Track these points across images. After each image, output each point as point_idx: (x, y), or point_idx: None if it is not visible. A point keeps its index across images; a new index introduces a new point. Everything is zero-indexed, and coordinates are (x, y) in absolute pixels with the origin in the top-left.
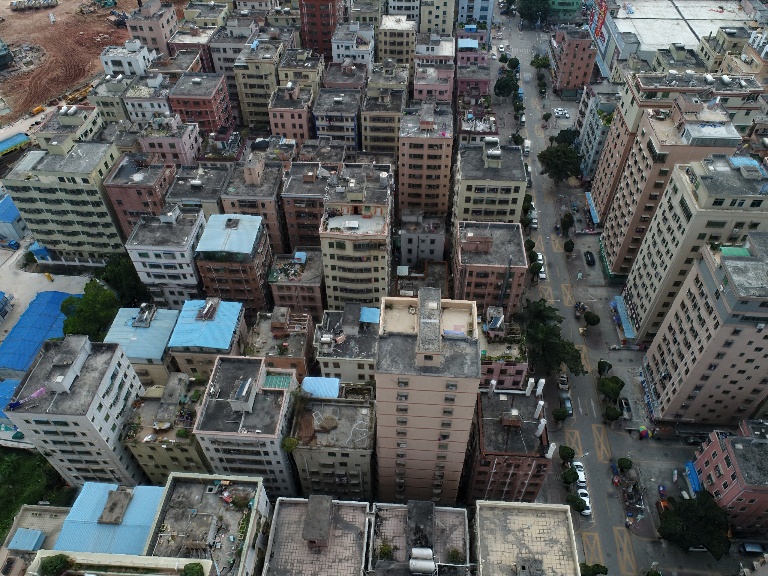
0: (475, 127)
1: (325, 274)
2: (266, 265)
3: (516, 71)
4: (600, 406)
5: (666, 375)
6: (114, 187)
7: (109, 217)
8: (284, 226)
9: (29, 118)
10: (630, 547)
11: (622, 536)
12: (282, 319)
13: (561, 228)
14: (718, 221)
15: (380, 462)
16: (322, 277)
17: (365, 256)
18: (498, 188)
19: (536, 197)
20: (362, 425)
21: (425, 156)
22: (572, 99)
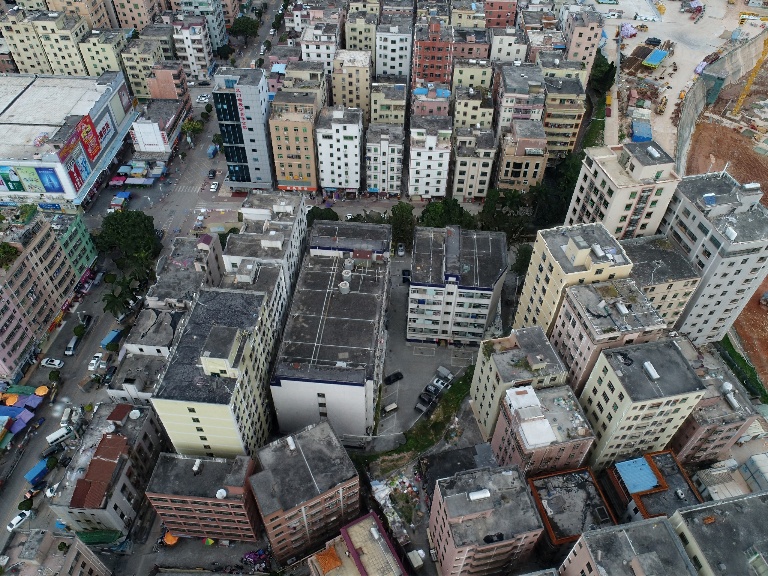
0: (303, 3)
1: None
2: None
3: None
4: None
5: None
6: None
7: None
8: None
9: None
10: None
11: None
12: None
13: None
14: None
15: None
16: None
17: None
18: None
19: (265, 39)
20: None
21: None
22: None
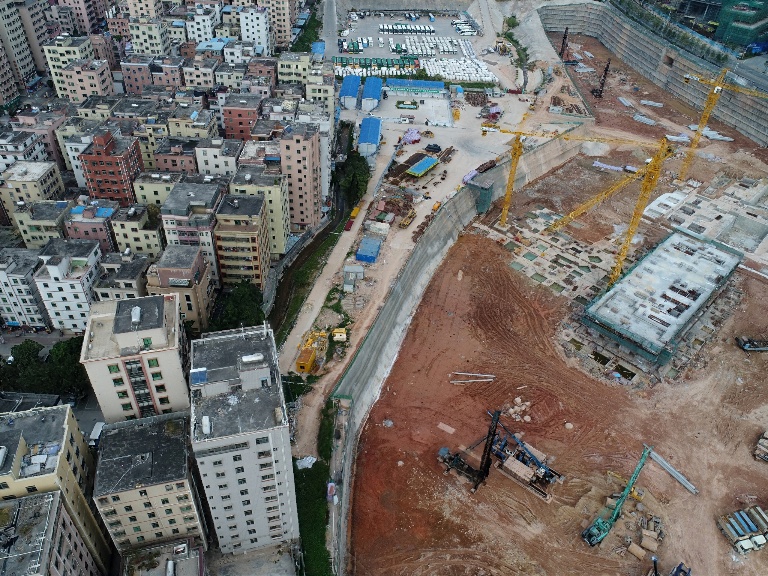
0: None
1: None
2: None
3: None
4: None
5: None
6: None
7: None
8: None
9: None
10: None
11: None
12: (191, 39)
13: None
14: None
15: None
16: None
17: None
18: None
19: None
20: None
21: None
22: None
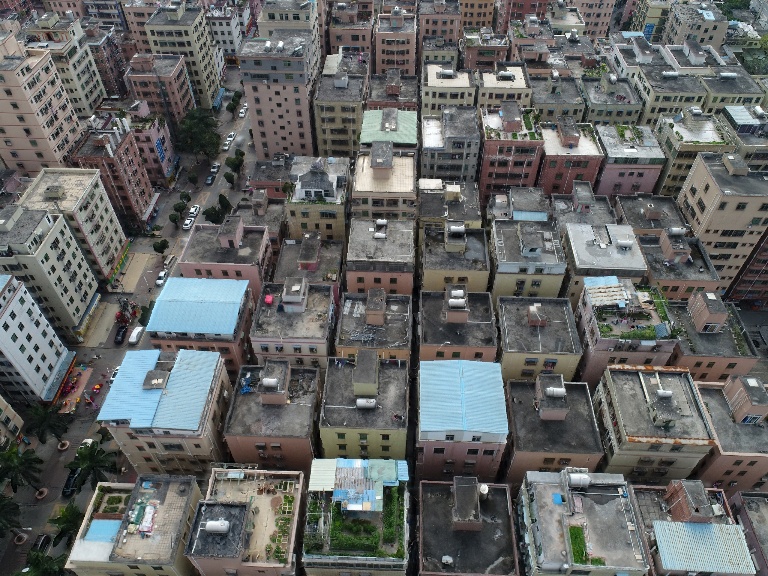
0: (212, 13)
1: None
2: None
3: None
4: None
5: None
6: None
7: None
8: None
9: None
10: None
11: None
12: None
13: None
14: None
15: (8, 166)
16: None
17: None
18: (173, 32)
19: None
20: None
21: None
22: None
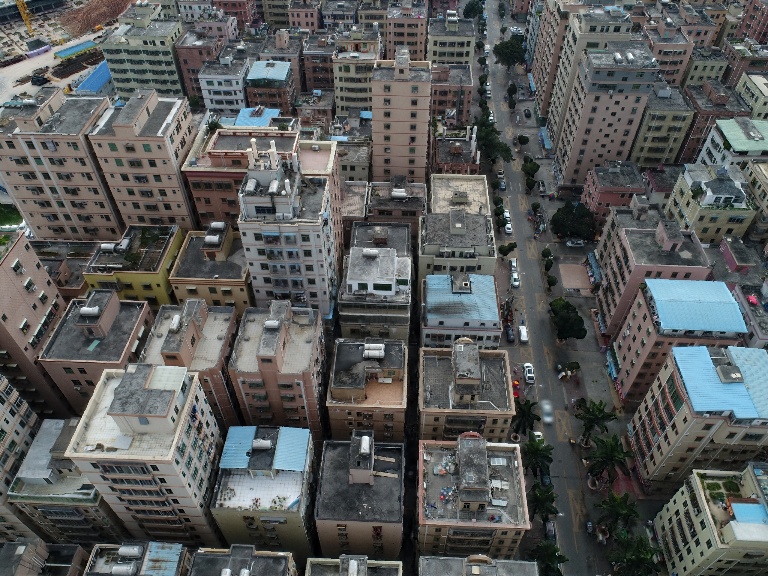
0: None
1: (336, 95)
2: (293, 99)
3: (482, 3)
4: (525, 186)
5: (564, 152)
6: (183, 48)
7: (176, 75)
8: (303, 84)
9: (92, 34)
10: (535, 247)
11: (531, 242)
12: (308, 115)
13: (508, 97)
14: (593, 42)
15: (374, 171)
16: (333, 104)
17: (363, 78)
18: (455, 43)
19: (491, 80)
20: (363, 154)
21: (405, 34)
22: (525, 21)
